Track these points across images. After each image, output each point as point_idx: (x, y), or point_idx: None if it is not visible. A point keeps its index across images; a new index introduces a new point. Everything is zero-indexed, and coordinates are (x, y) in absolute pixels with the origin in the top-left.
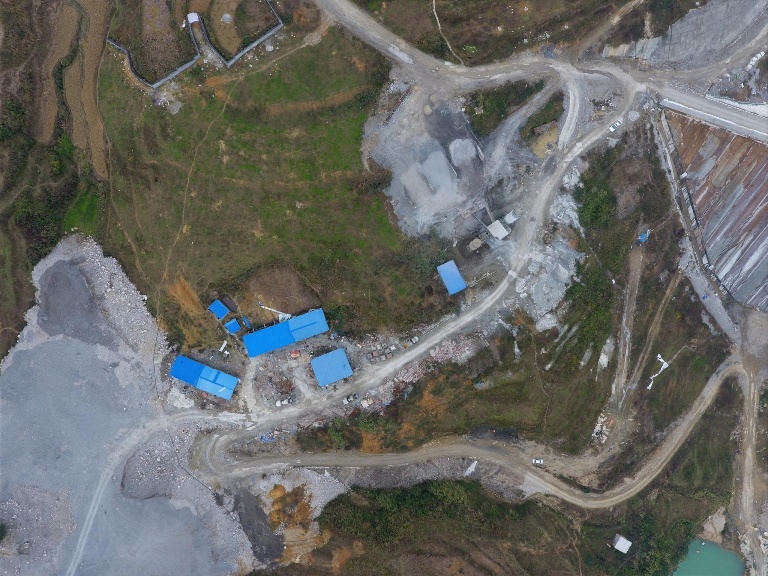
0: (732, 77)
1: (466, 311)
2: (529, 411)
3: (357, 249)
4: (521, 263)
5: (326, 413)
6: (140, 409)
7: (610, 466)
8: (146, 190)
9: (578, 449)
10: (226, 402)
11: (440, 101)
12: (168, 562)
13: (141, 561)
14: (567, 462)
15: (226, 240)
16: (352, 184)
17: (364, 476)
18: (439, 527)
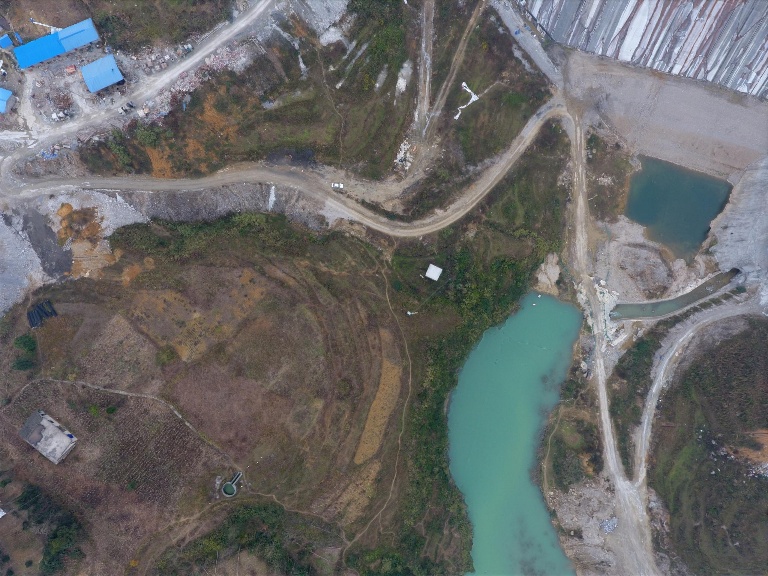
0: None
1: (239, 17)
2: (322, 132)
3: None
4: None
5: (104, 125)
6: None
7: (414, 191)
8: None
9: (379, 174)
10: (5, 119)
11: None
12: None
13: None
14: (369, 187)
15: None
16: None
17: (160, 203)
18: (232, 243)
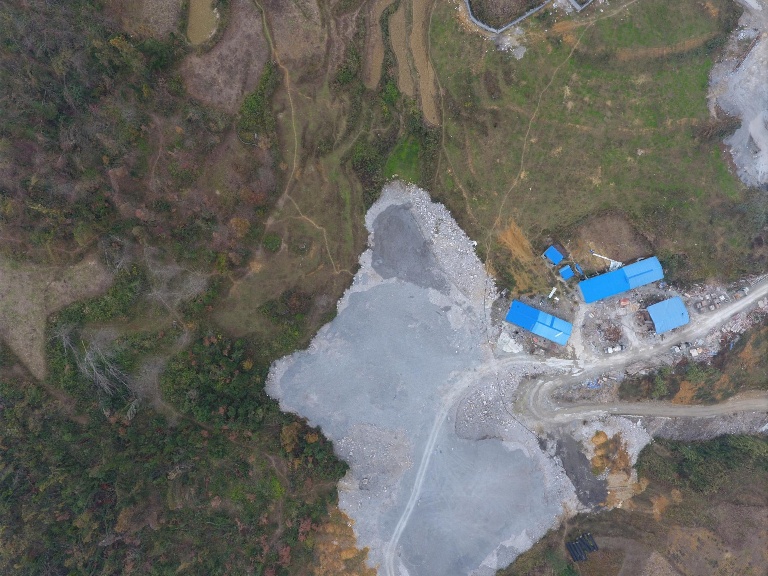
0: None
1: None
2: None
3: (693, 198)
4: None
5: (654, 361)
6: (471, 353)
7: None
8: (481, 136)
9: None
10: (556, 348)
11: None
12: (503, 502)
13: (477, 500)
14: None
15: (563, 187)
16: (696, 132)
17: (672, 427)
18: (752, 478)
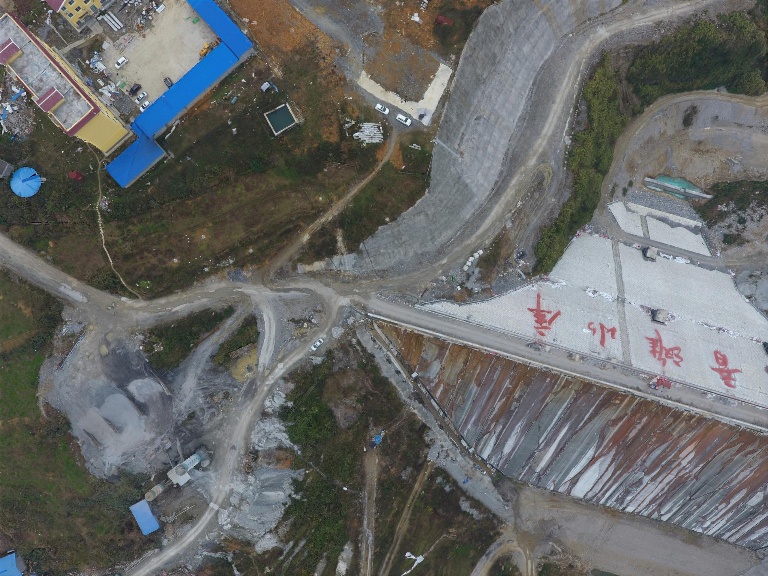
0: (448, 279)
1: (169, 545)
2: None
3: (47, 492)
4: (222, 494)
5: None
6: None
7: None
8: None
9: None
10: None
11: (117, 340)
12: None
13: None
14: None
15: None
16: (32, 430)
17: None
18: None
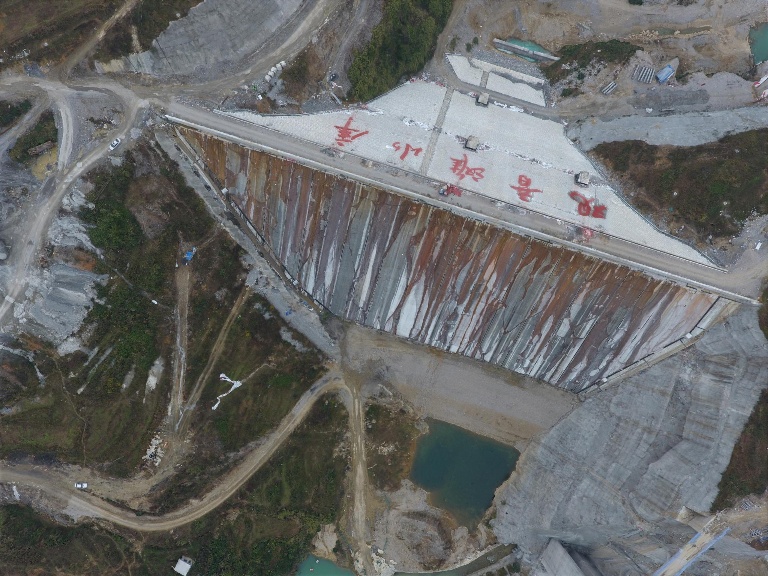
0: (250, 89)
1: None
2: (63, 435)
3: None
4: (18, 288)
5: None
6: None
7: (163, 489)
8: None
9: (126, 472)
10: None
11: None
12: None
13: None
14: (115, 485)
15: None
16: None
17: None
18: None
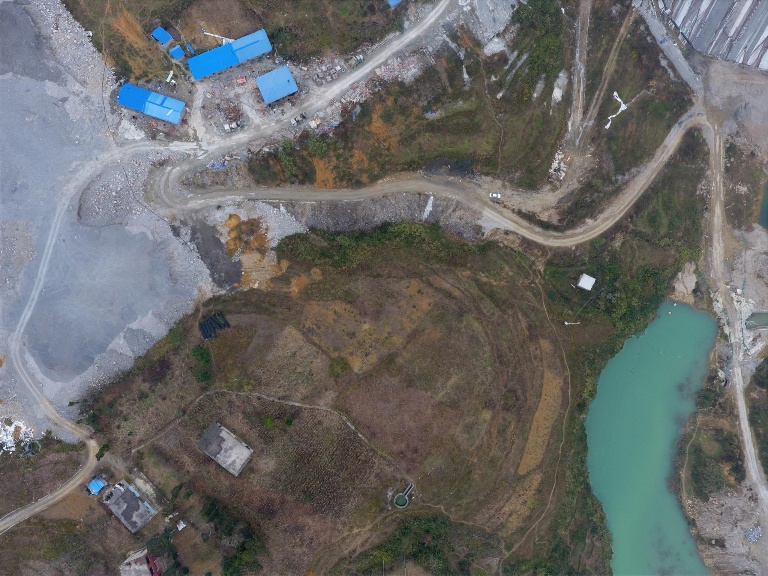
0: None
1: (410, 28)
2: (483, 142)
3: None
4: None
5: (275, 136)
6: (92, 142)
7: (569, 201)
8: None
9: (536, 184)
10: (176, 130)
11: None
12: (127, 285)
13: (101, 285)
14: (525, 197)
15: None
16: None
17: (320, 213)
18: (396, 254)
